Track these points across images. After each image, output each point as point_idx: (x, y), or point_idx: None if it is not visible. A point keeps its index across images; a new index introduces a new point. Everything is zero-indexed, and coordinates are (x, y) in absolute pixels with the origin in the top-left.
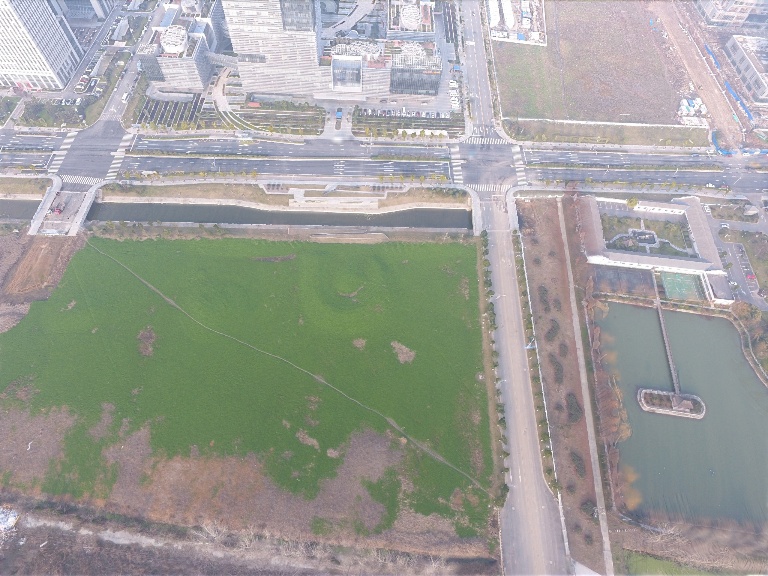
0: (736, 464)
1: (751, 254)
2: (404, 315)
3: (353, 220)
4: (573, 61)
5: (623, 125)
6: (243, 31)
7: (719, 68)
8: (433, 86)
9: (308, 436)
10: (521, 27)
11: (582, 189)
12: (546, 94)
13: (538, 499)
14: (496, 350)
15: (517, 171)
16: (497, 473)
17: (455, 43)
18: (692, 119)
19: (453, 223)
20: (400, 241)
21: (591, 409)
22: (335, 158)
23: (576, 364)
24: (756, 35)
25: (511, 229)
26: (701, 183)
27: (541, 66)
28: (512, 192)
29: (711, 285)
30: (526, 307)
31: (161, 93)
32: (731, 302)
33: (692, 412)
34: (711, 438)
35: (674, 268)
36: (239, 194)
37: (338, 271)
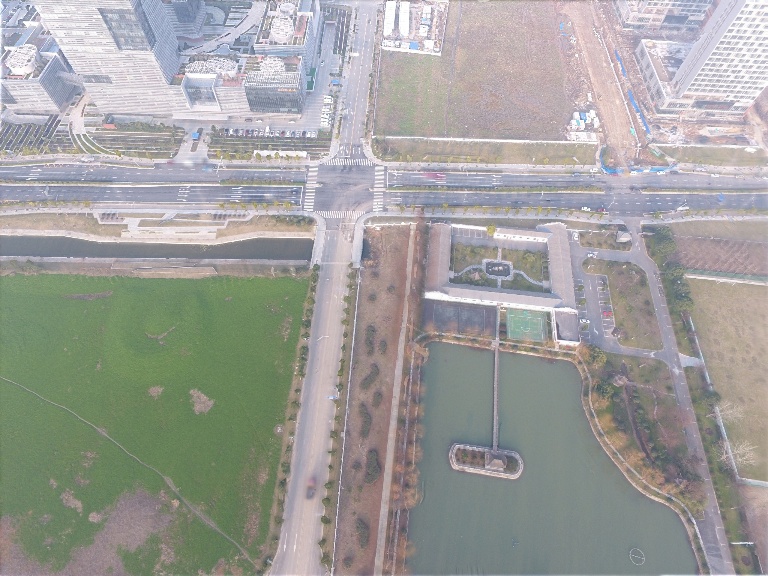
0: (546, 532)
1: (613, 287)
2: (212, 359)
3: (187, 252)
4: (466, 71)
5: (504, 142)
6: (77, 52)
7: (625, 76)
8: (294, 104)
9: (73, 497)
10: (418, 35)
11: (442, 215)
12: (427, 109)
13: (309, 573)
14: (303, 399)
15: (375, 195)
16: (270, 542)
17: (342, 54)
18: (580, 134)
19: (294, 254)
20: (228, 275)
21: (392, 468)
22: (181, 183)
23: (388, 415)
24: (675, 38)
25: (352, 261)
26: (576, 206)
27: (429, 78)
28: (363, 219)
29: (557, 324)
30: (348, 350)
31: (16, 115)
32: (577, 343)
33: (506, 471)
34: (522, 502)
35: (520, 305)
36: (70, 224)
37: (152, 310)
